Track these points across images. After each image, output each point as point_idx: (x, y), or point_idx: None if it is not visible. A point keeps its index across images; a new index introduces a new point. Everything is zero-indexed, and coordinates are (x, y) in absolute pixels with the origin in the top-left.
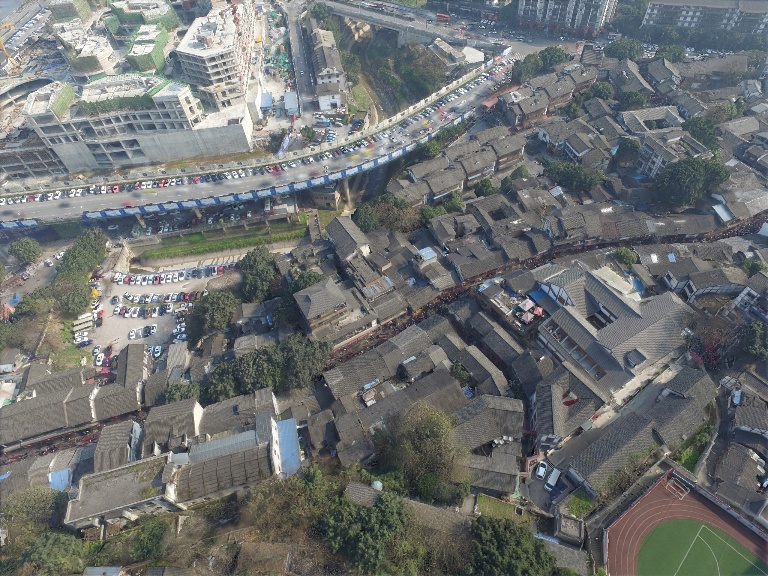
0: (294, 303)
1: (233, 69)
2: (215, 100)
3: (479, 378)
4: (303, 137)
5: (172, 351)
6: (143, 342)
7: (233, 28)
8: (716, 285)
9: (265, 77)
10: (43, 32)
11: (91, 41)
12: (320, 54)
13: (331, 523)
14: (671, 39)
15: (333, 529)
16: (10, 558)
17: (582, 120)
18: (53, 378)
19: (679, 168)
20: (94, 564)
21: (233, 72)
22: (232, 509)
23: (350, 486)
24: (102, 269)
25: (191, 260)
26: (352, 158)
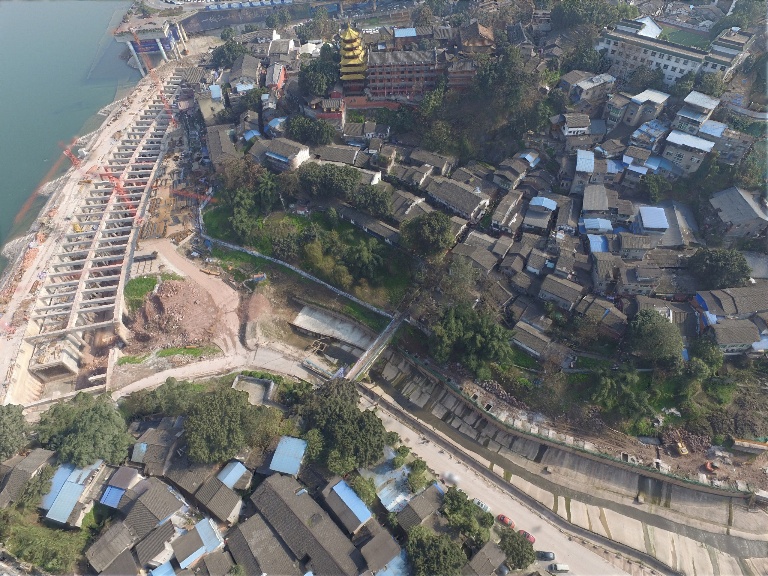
0: (467, 2)
1: None
2: None
3: None
4: None
5: None
6: None
7: None
8: None
9: None
10: None
11: None
12: None
13: None
14: None
15: None
16: None
17: None
18: None
19: None
20: None
21: None
22: None
23: None
24: None
25: None
26: None
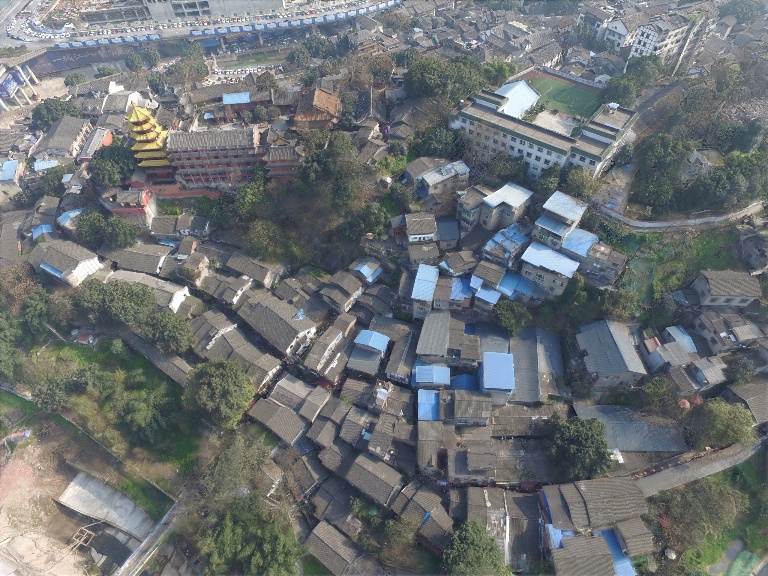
0: (346, 44)
1: None
2: None
3: None
4: None
5: (275, 77)
6: None
7: None
8: (570, 25)
9: None
10: None
11: None
12: None
13: None
14: None
15: (393, 55)
16: None
17: None
18: (211, 85)
19: None
20: None
21: None
22: None
23: None
24: None
25: None
26: None
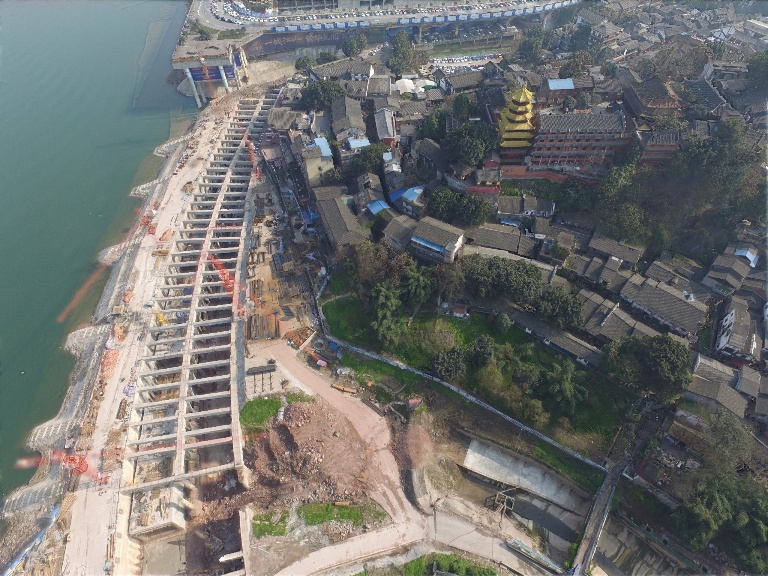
0: (586, 36)
1: None
2: None
3: None
4: None
5: (512, 67)
6: None
7: None
8: None
9: None
10: None
11: None
12: None
13: (700, 45)
14: None
15: None
16: None
17: None
18: None
19: None
20: None
21: None
22: None
23: None
24: None
25: None
26: (551, 1)
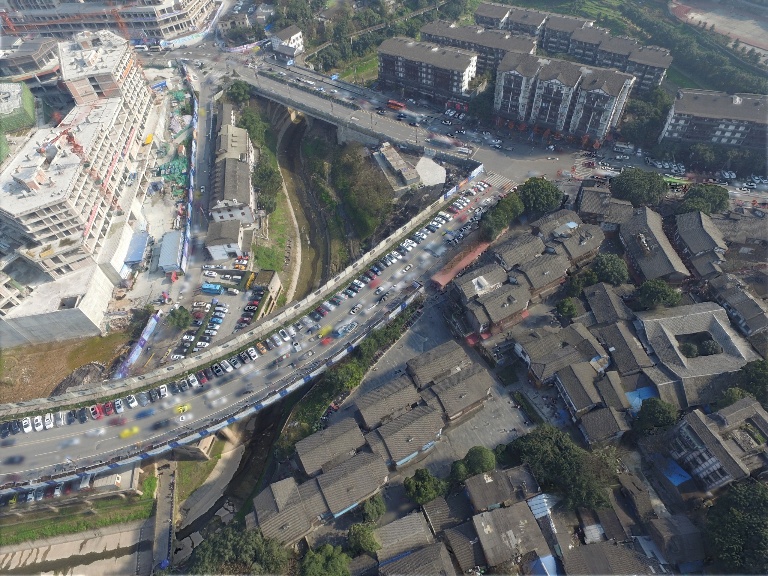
0: None
1: (71, 221)
2: (43, 269)
3: None
4: None
5: None
6: None
7: None
8: None
9: (151, 196)
10: None
11: None
12: (221, 172)
13: None
14: (703, 161)
15: None
16: None
17: (581, 324)
18: None
19: (761, 532)
20: None
21: (72, 225)
22: None
23: None
24: None
25: None
26: (228, 387)
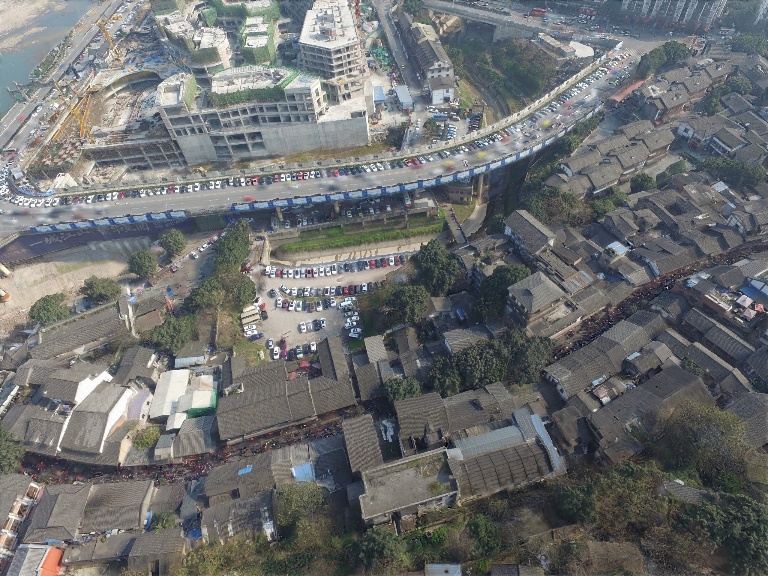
0: (502, 297)
1: (355, 62)
2: (337, 93)
3: (716, 375)
4: (422, 131)
5: (369, 345)
6: (315, 336)
7: (350, 20)
8: None
9: None
10: (133, 25)
11: (208, 33)
12: (427, 48)
13: (705, 522)
14: None
15: (708, 529)
16: (292, 554)
17: (723, 115)
18: (258, 371)
19: None
20: (423, 561)
21: (354, 65)
22: (515, 506)
23: (667, 484)
24: (249, 262)
25: (328, 254)
26: (489, 152)
